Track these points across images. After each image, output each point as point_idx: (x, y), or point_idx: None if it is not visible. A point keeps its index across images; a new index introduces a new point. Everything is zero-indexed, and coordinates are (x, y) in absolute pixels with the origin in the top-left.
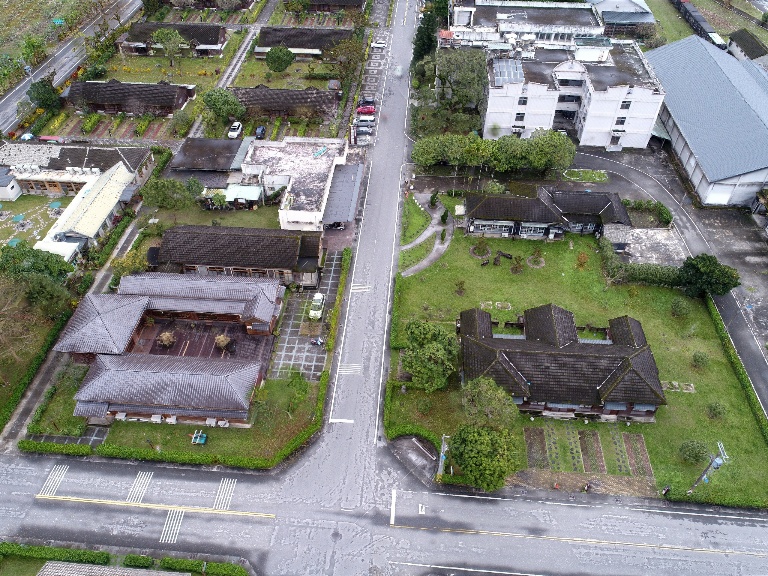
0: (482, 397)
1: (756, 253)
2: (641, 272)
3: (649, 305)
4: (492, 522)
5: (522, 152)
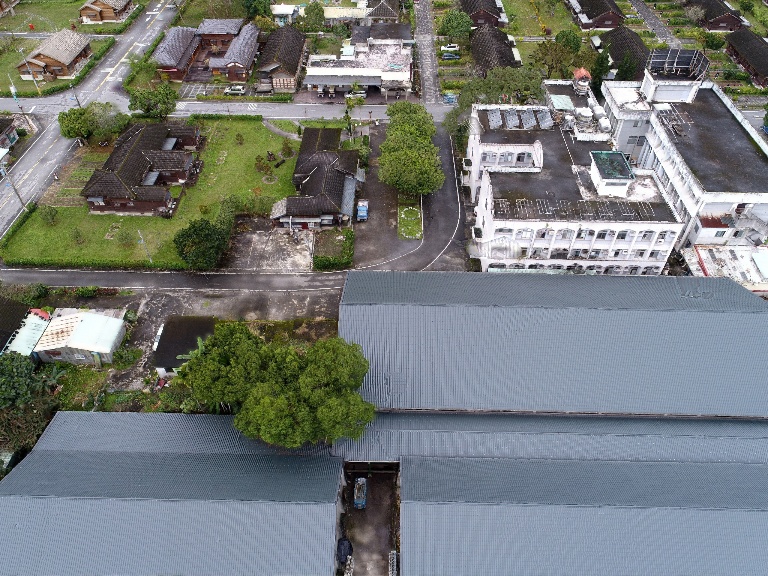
0: None
1: None
2: None
3: None
4: (57, 147)
5: (391, 145)
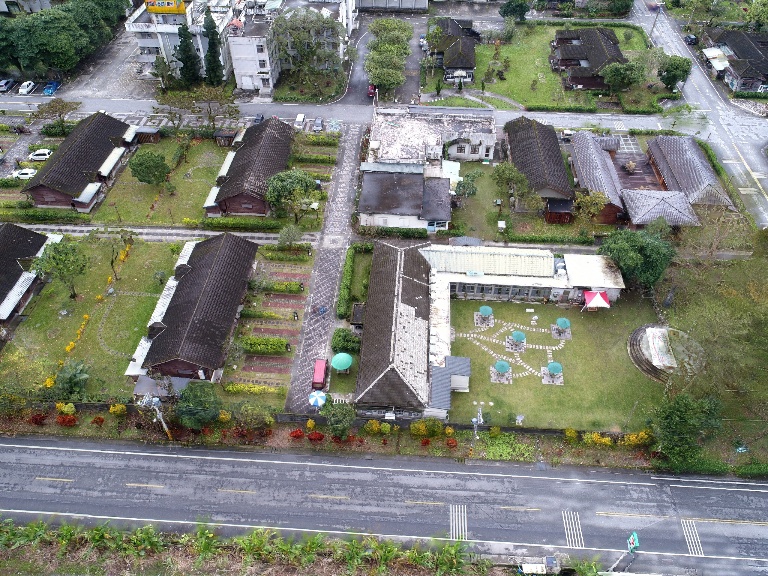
0: (659, 52)
1: (471, 6)
2: None
3: (525, 37)
4: None
5: None
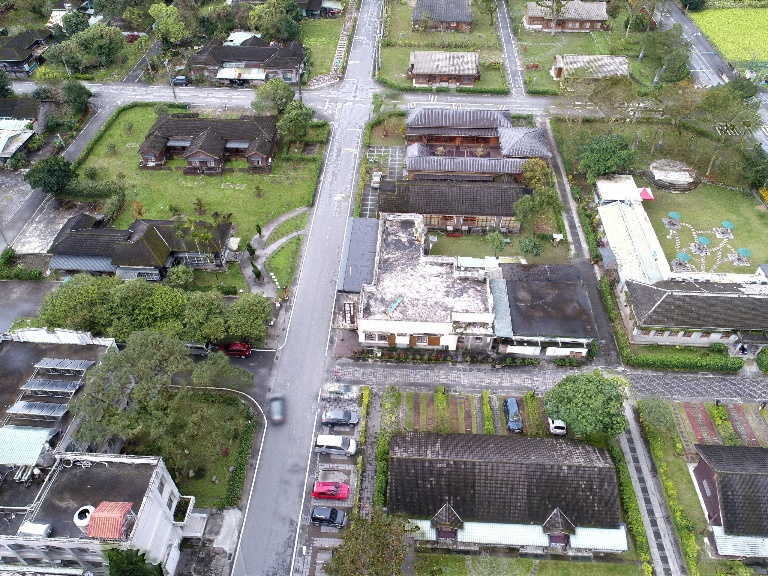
0: None
1: None
2: (102, 183)
3: None
4: None
5: None
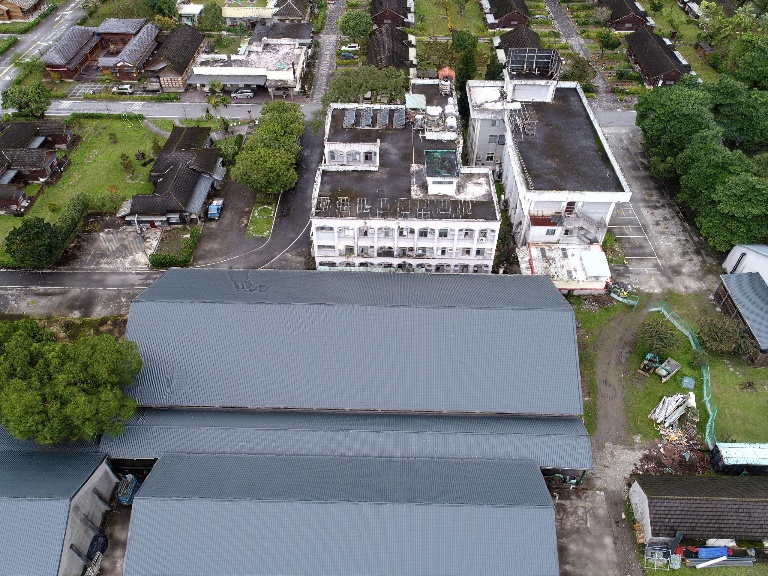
0: None
1: None
2: None
3: None
4: None
5: (249, 144)
